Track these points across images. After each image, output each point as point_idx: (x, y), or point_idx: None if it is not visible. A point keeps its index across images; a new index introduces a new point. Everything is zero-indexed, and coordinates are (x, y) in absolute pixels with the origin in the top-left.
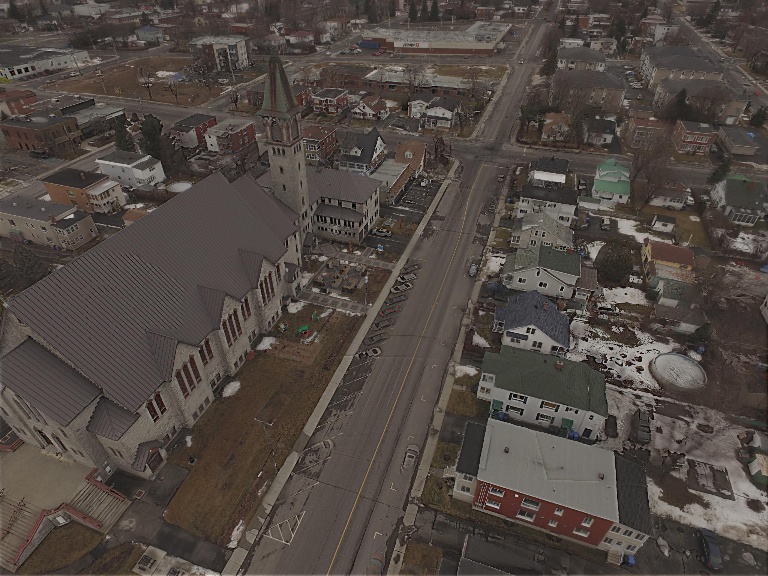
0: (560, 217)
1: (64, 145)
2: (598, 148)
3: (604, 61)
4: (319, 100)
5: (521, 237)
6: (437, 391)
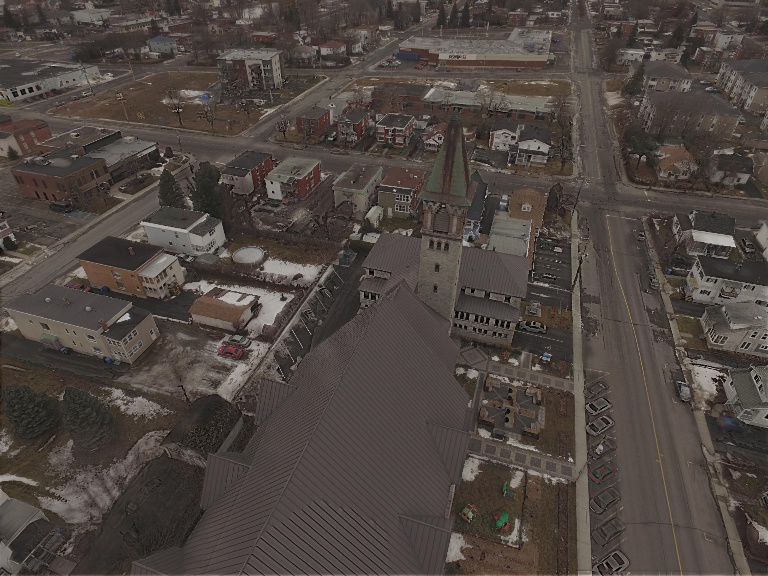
0: (757, 301)
1: (91, 193)
2: (731, 190)
3: (691, 78)
4: (385, 129)
5: (729, 338)
6: None
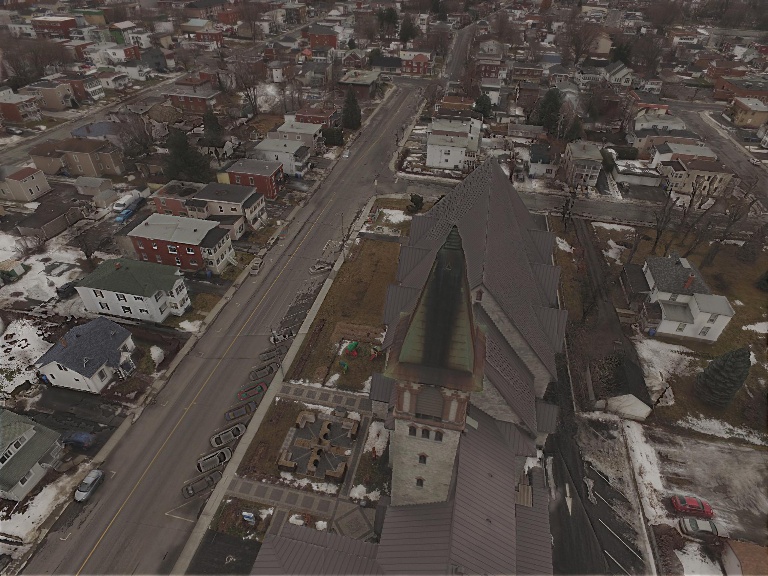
0: None
1: None
2: None
3: None
4: None
5: None
6: (224, 311)
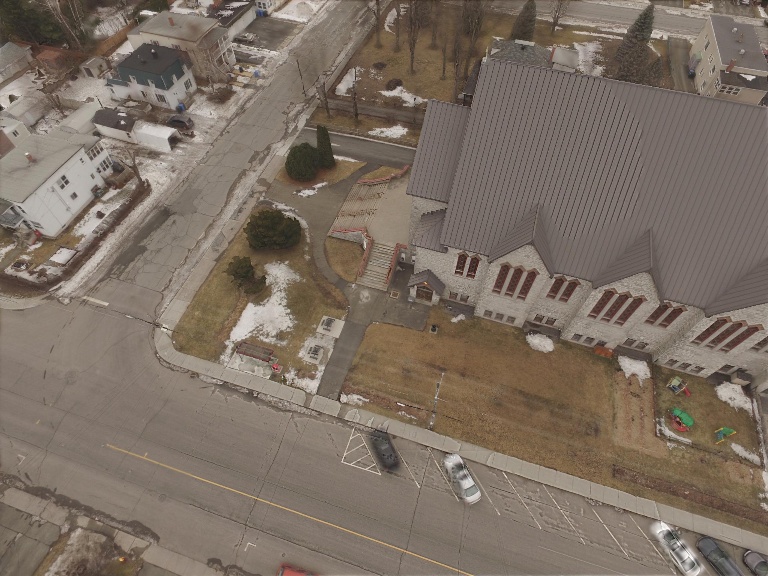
0: None
1: None
2: None
3: None
4: None
5: None
6: None
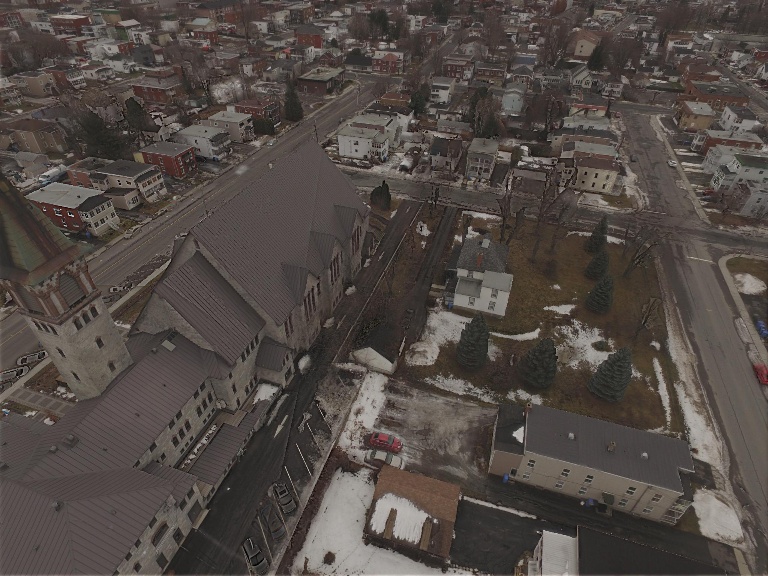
0: None
1: None
2: None
3: None
4: None
5: None
6: None
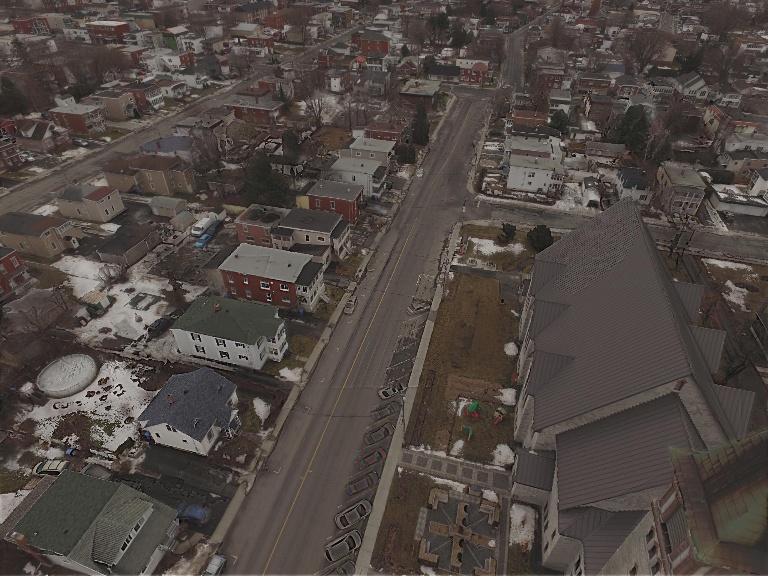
0: None
1: None
2: None
3: None
4: None
5: None
6: (323, 356)
